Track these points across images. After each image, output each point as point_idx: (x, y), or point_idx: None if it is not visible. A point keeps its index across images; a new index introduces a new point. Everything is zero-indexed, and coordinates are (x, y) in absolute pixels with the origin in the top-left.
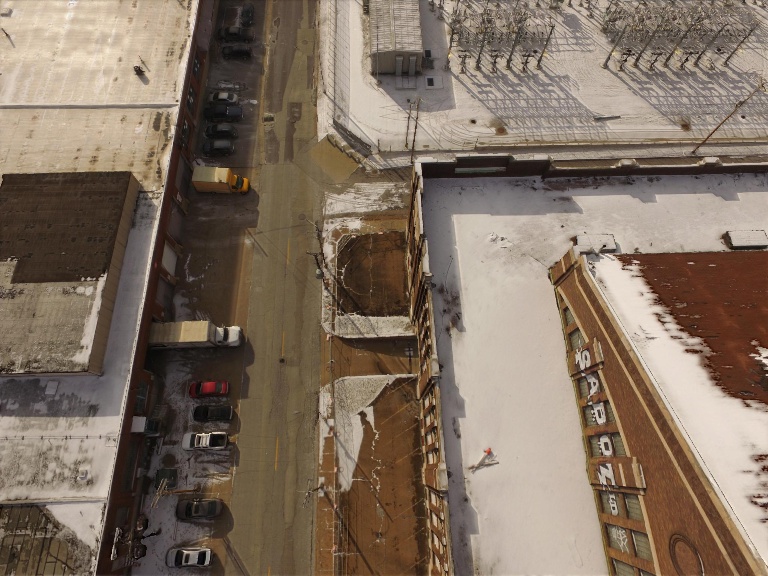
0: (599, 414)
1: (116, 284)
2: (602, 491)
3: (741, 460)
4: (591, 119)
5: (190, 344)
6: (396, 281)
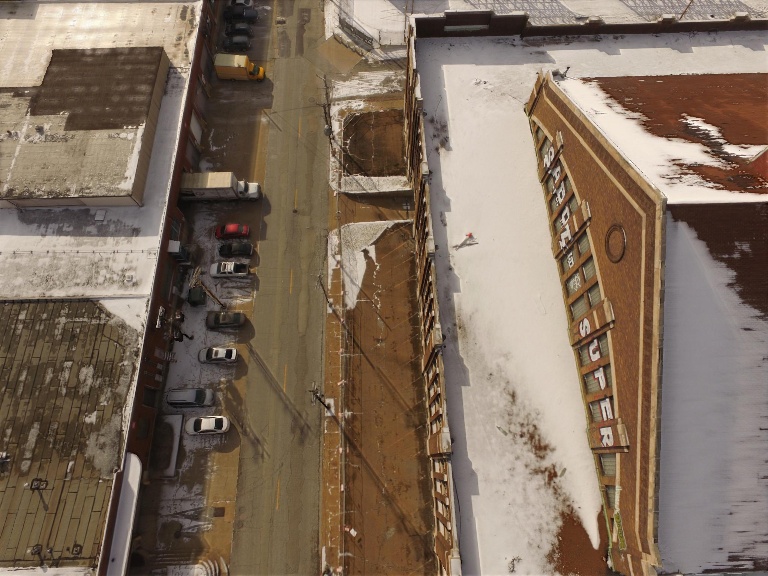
0: (561, 195)
1: (152, 136)
2: (563, 258)
3: (657, 161)
4: (573, 19)
5: (216, 193)
6: (395, 148)
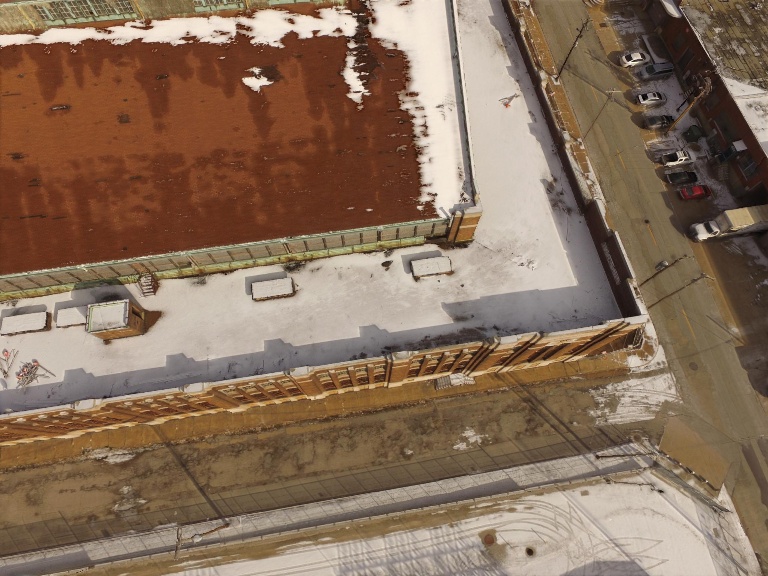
0: None
1: None
2: None
3: None
4: None
5: None
6: None
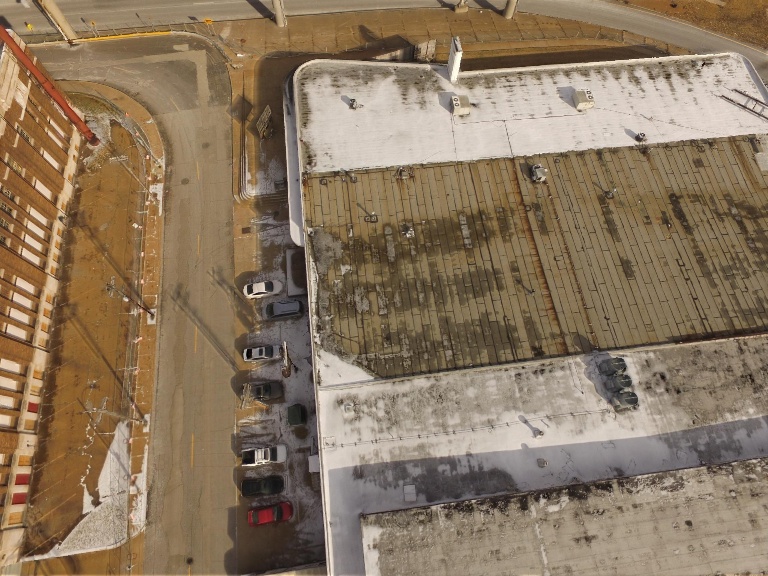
0: None
1: None
2: None
3: None
4: None
5: None
6: None
